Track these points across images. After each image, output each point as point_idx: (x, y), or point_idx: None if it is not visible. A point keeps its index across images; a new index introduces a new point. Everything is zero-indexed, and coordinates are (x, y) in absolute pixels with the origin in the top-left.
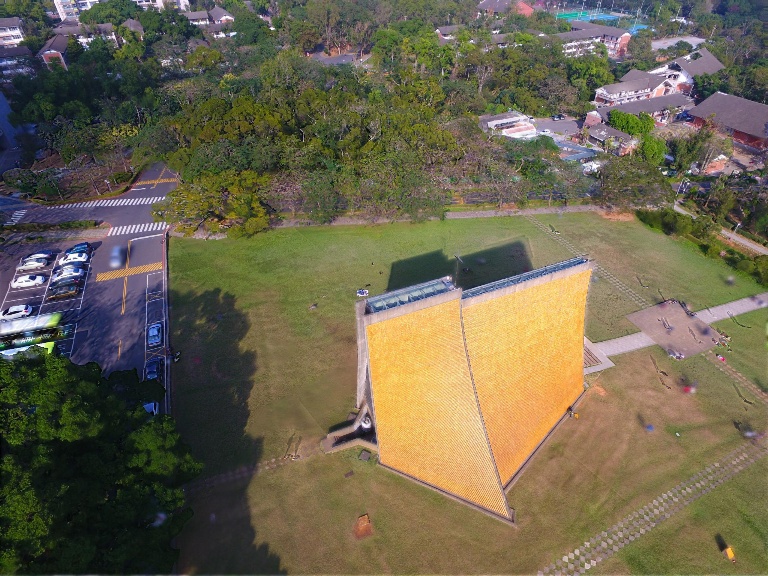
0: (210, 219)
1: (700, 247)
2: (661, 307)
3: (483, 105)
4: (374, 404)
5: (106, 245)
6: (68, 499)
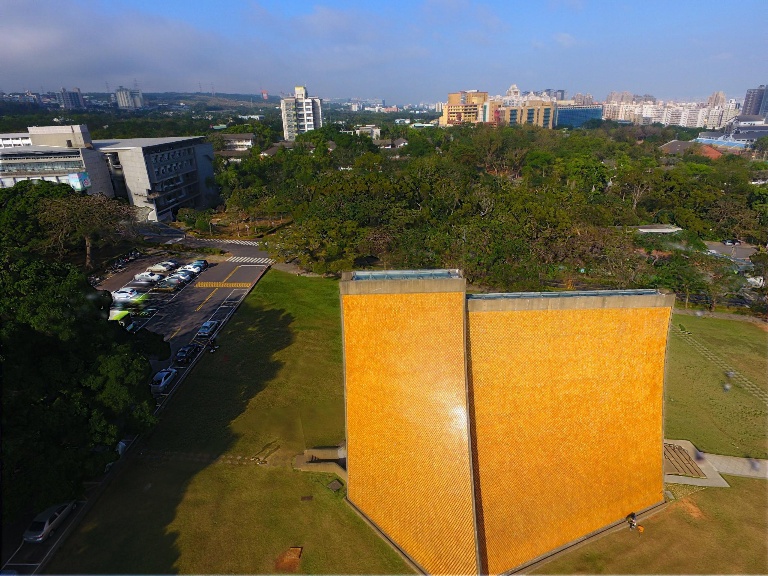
0: (311, 262)
1: None
2: None
3: (633, 219)
4: (347, 408)
5: (219, 266)
6: (4, 377)
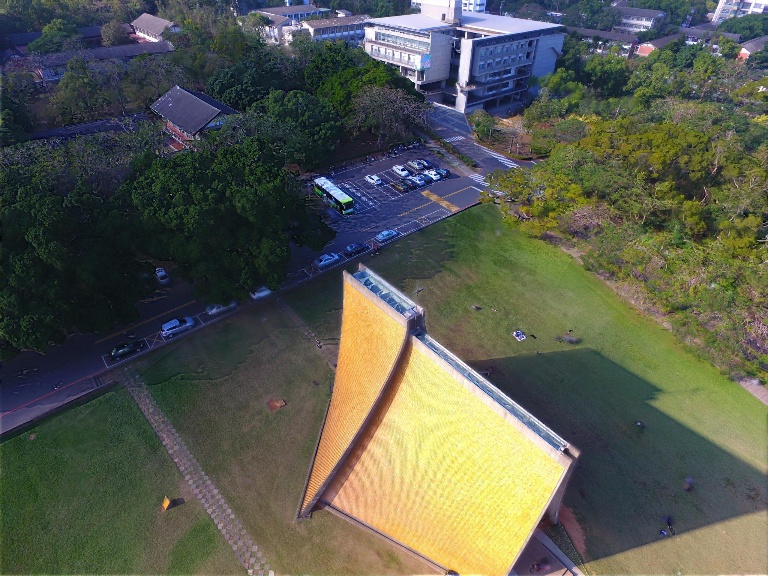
0: None
1: None
2: None
3: None
4: None
5: (458, 180)
6: (215, 231)
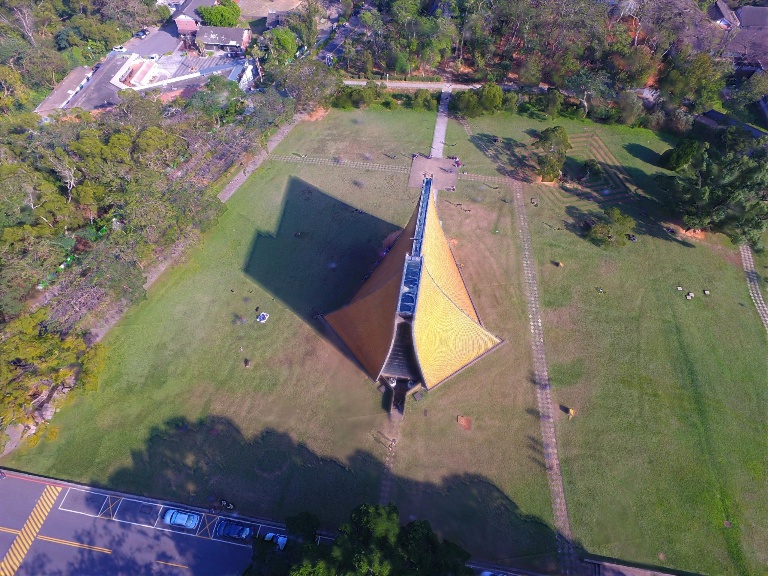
0: None
1: (382, 105)
2: (415, 165)
3: (64, 60)
4: (420, 363)
5: None
6: None
